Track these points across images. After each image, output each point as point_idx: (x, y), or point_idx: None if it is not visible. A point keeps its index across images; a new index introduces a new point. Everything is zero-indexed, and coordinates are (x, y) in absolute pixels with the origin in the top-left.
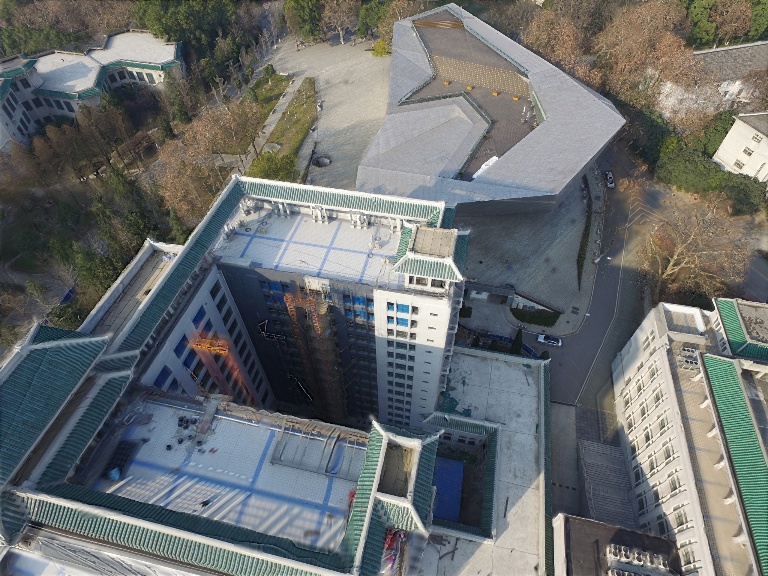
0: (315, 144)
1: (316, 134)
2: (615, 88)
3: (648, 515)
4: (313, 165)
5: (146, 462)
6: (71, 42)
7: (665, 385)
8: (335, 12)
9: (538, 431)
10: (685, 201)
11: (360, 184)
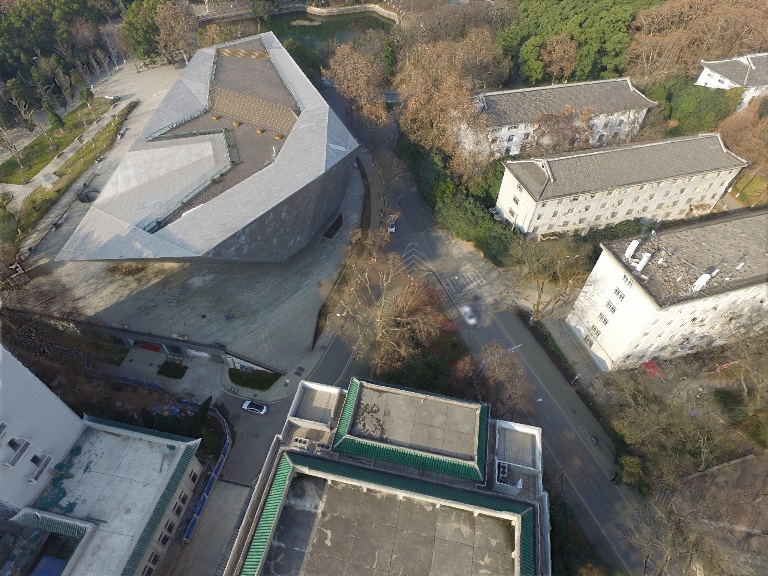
0: (94, 176)
1: (101, 165)
2: (405, 127)
3: None
4: (78, 200)
5: None
6: None
7: None
8: (169, 35)
9: None
10: (462, 249)
11: (79, 228)
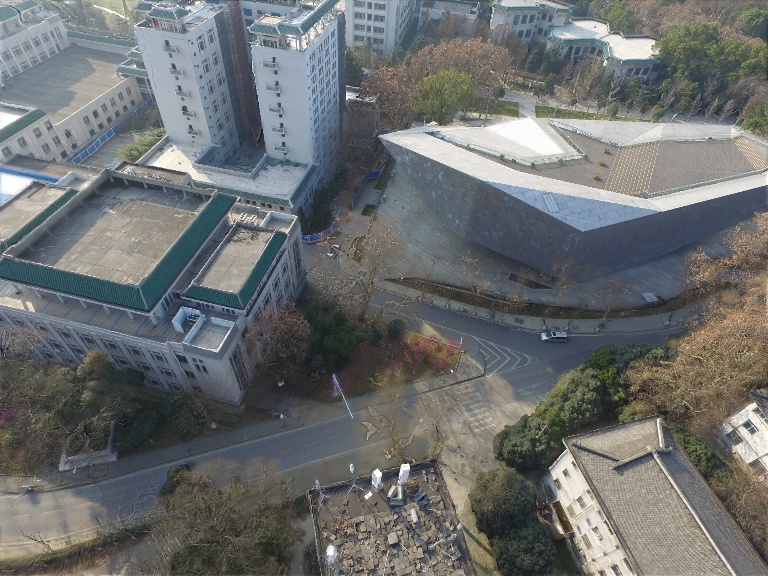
0: None
1: None
2: (706, 313)
3: None
4: None
5: (210, 4)
6: (625, 26)
7: None
8: None
9: None
10: None
11: None
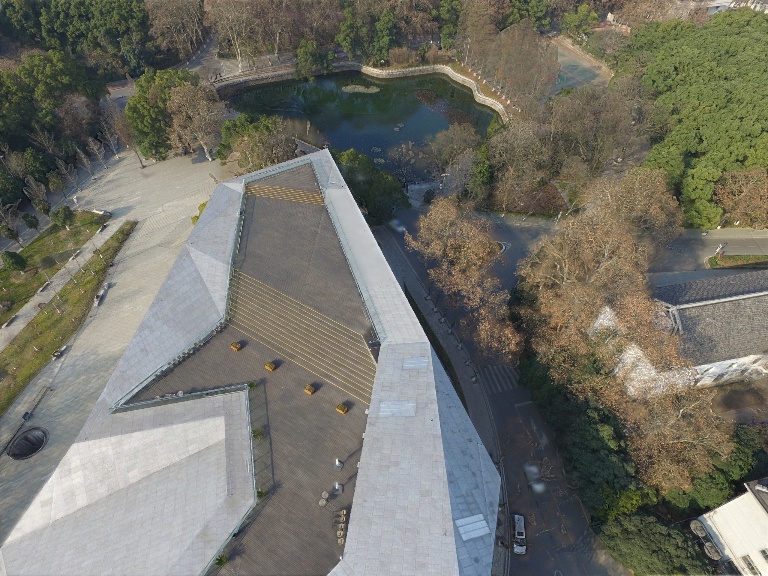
0: (44, 392)
1: (59, 365)
2: (544, 357)
3: None
4: (9, 452)
5: None
6: None
7: None
8: (185, 127)
9: None
10: None
11: None
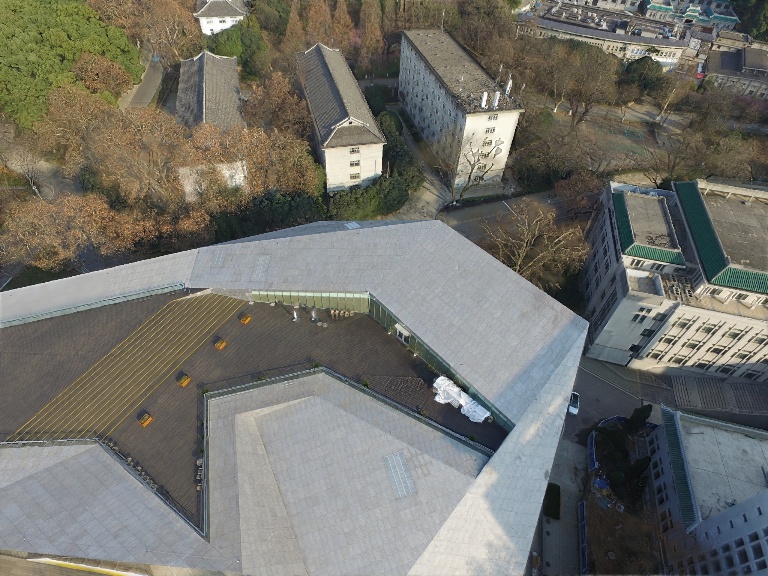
0: None
1: None
2: (217, 210)
3: (767, 373)
4: None
5: None
6: None
7: (714, 319)
8: None
9: (754, 437)
10: None
11: None
